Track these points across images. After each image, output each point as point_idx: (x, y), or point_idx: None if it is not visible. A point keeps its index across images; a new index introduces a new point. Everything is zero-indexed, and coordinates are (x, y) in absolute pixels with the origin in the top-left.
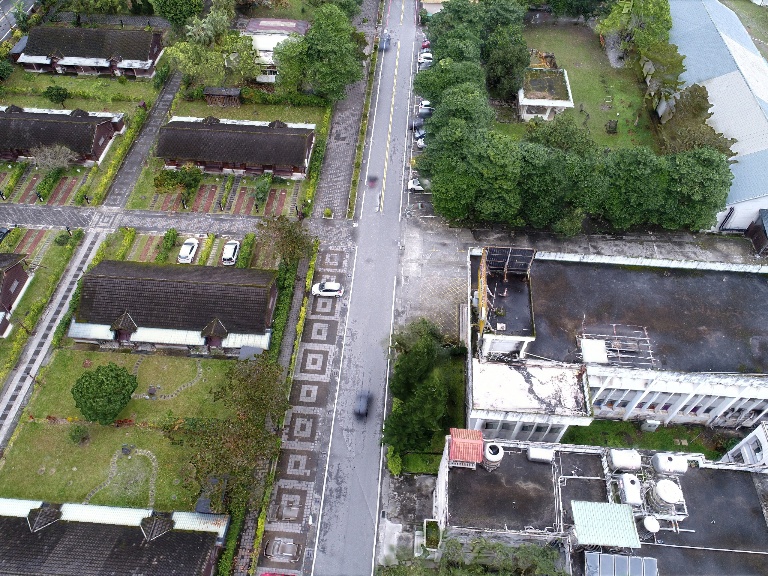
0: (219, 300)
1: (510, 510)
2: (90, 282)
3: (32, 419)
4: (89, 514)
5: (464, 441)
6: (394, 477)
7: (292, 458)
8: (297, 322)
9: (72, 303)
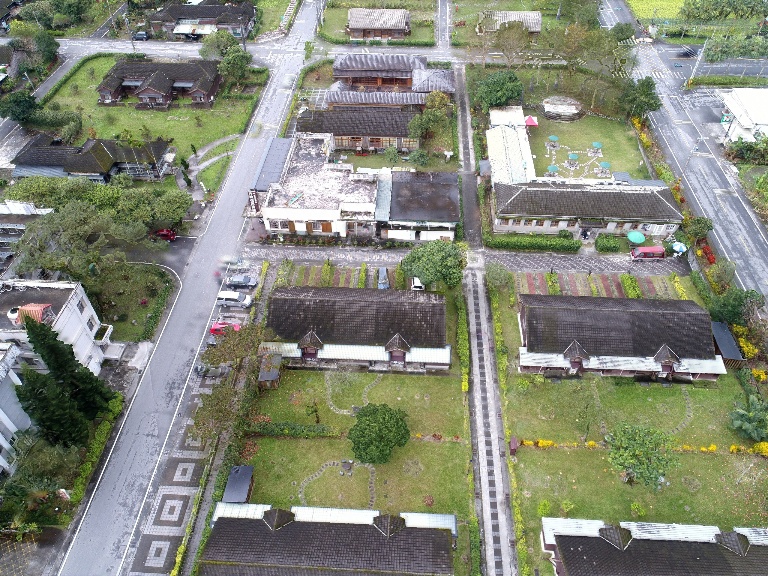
0: (268, 548)
1: (29, 299)
2: (443, 568)
3: (459, 440)
4: (365, 352)
5: (34, 308)
6: None
7: None
8: (184, 567)
9: (476, 575)
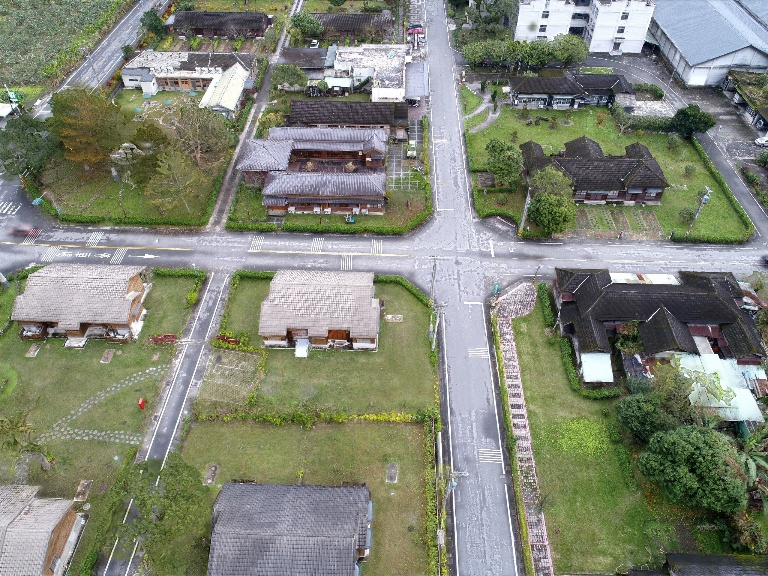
0: None
1: None
2: None
3: None
4: None
5: None
6: (452, 18)
7: (412, 16)
8: None
9: None
